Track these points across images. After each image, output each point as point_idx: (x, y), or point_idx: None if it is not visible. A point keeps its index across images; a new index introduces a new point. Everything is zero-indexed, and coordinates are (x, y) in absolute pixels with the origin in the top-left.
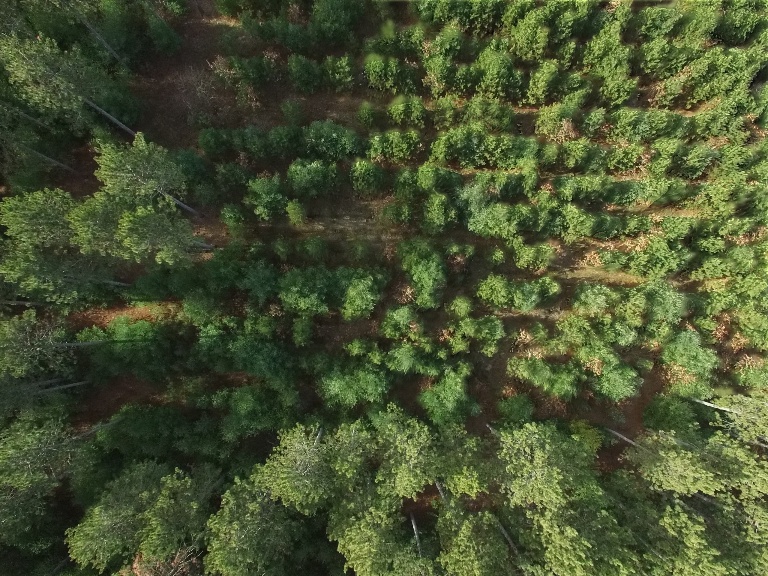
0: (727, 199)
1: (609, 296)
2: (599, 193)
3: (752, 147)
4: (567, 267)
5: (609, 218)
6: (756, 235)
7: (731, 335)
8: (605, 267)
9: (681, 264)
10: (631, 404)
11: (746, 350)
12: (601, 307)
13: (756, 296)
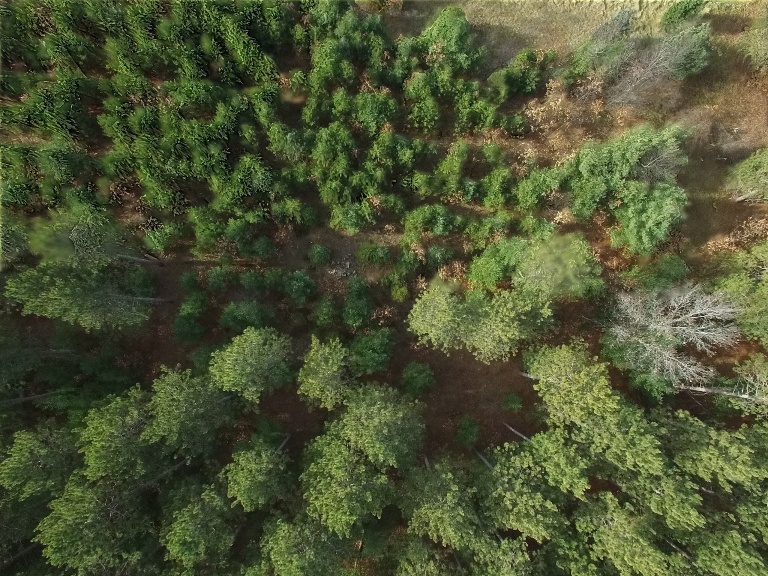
0: (138, 64)
1: (2, 153)
2: (10, 55)
3: (168, 14)
4: (14, 137)
5: (4, 76)
6: (170, 101)
7: (138, 197)
8: (23, 131)
9: (74, 123)
10: (24, 261)
11: (150, 212)
12: (4, 167)
13: (160, 159)
